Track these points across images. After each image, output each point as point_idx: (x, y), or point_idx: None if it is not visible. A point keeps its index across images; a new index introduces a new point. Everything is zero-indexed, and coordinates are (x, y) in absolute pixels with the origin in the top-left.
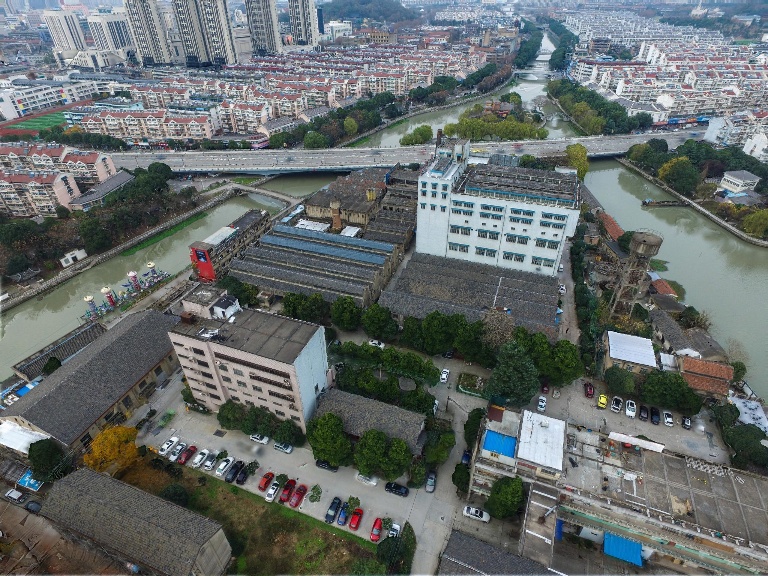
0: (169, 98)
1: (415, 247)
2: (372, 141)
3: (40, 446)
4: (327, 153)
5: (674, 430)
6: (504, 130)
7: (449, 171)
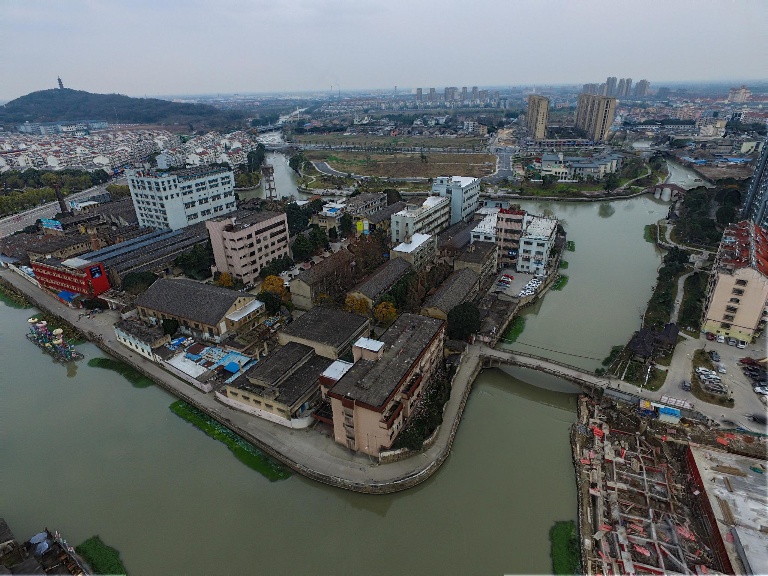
0: None
1: None
2: None
3: None
4: None
5: None
6: (37, 196)
7: None
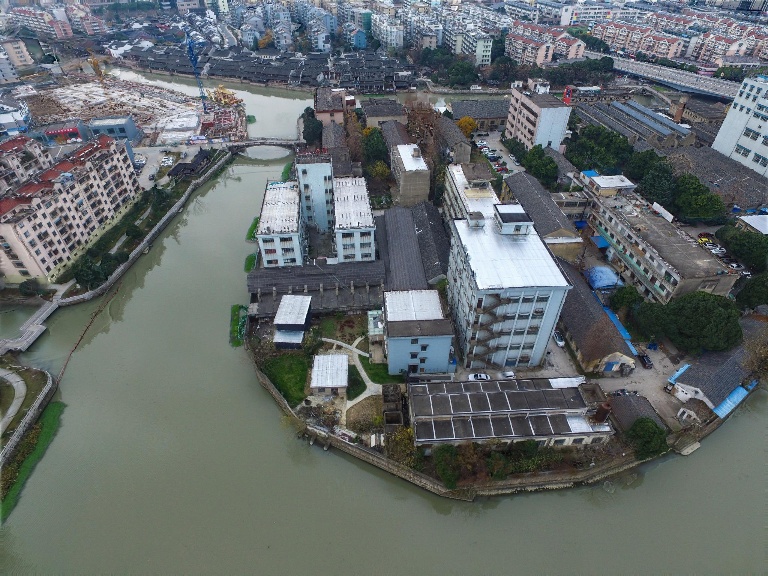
0: (674, 26)
1: None
2: None
3: (448, 111)
4: None
5: None
6: None
7: None
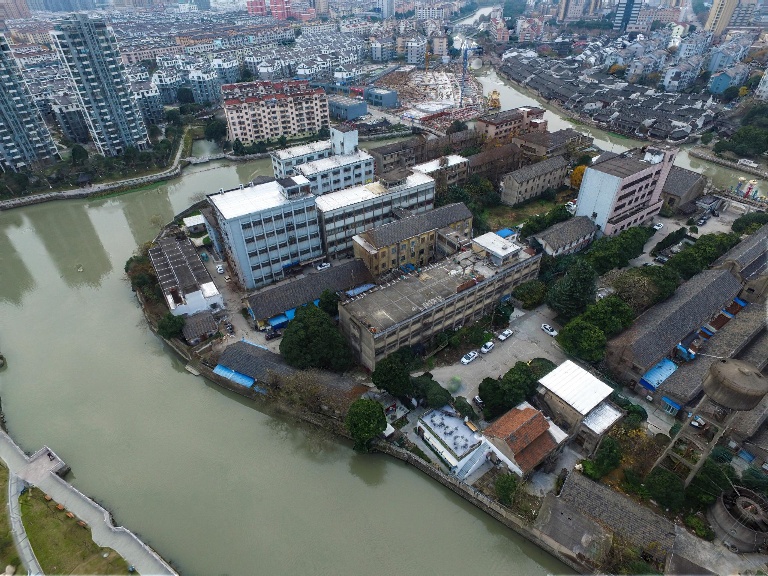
0: None
1: None
2: None
3: (586, 157)
4: None
5: None
6: None
7: None
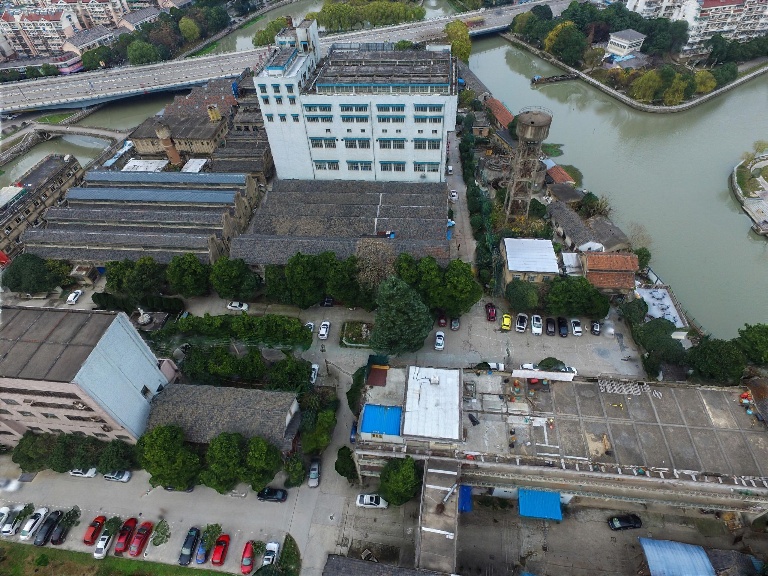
0: None
1: (277, 173)
2: (224, 47)
3: None
4: (161, 68)
5: (583, 339)
6: (375, 14)
7: (294, 66)
